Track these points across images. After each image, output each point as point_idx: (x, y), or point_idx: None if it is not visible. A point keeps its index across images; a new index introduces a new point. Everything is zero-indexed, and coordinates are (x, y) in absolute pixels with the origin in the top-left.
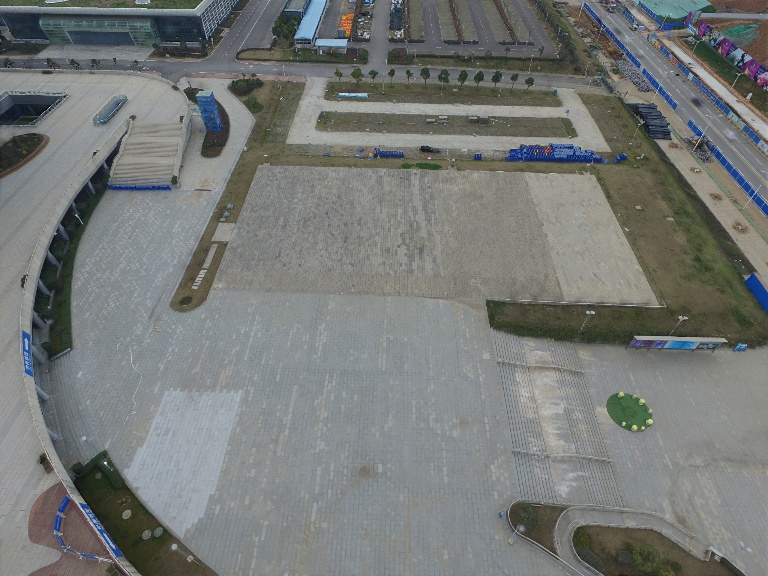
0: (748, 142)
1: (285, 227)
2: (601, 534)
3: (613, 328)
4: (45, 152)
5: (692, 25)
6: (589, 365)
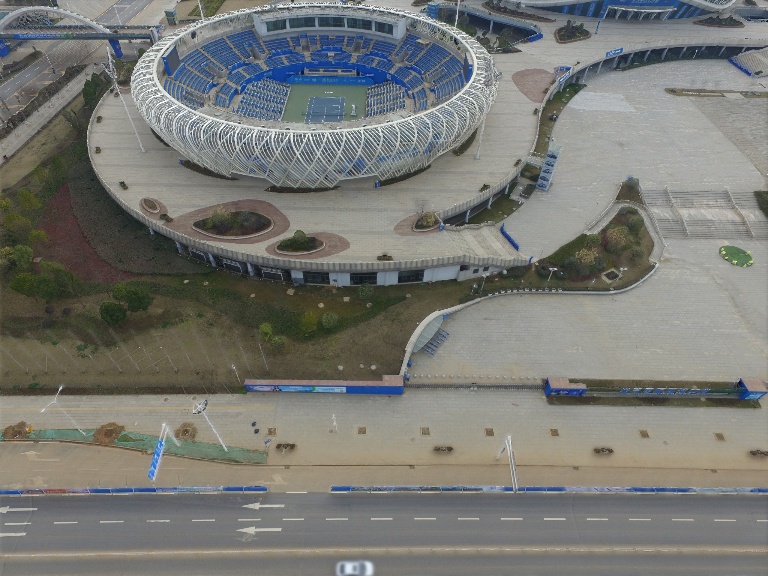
0: None
1: (762, 113)
2: None
3: None
4: (731, 29)
5: None
6: (764, 244)
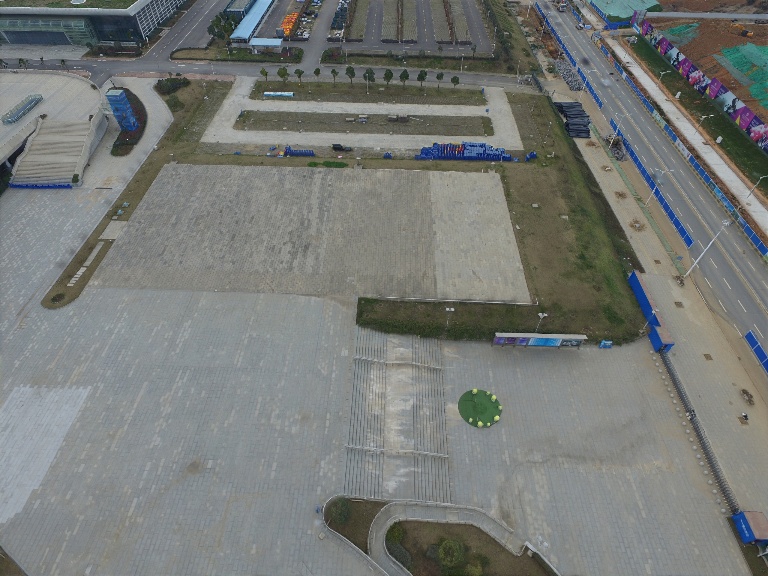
0: (667, 140)
1: (175, 225)
2: (418, 529)
3: (480, 325)
4: None
5: (638, 24)
6: (451, 362)
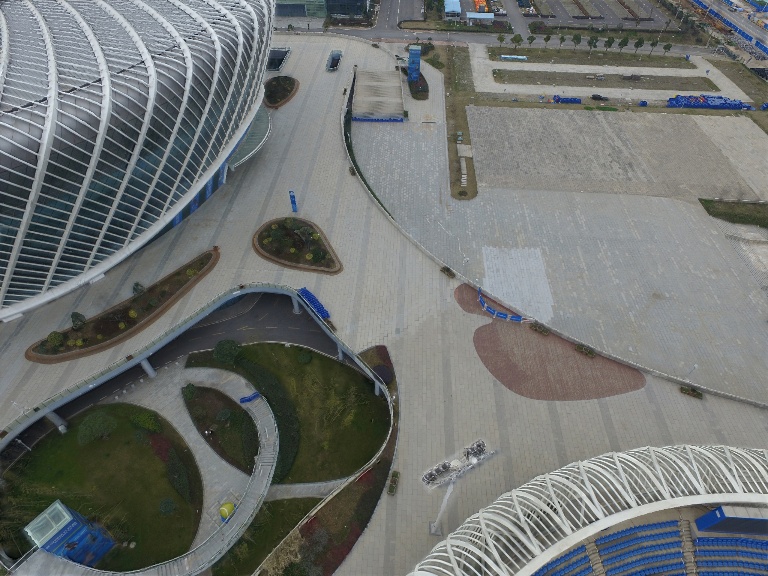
0: None
1: (512, 148)
2: None
3: None
4: (302, 90)
5: None
6: None
